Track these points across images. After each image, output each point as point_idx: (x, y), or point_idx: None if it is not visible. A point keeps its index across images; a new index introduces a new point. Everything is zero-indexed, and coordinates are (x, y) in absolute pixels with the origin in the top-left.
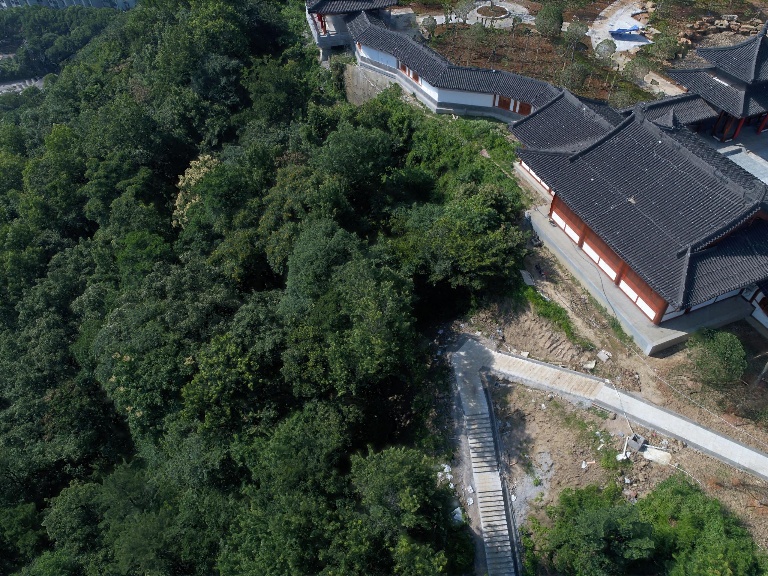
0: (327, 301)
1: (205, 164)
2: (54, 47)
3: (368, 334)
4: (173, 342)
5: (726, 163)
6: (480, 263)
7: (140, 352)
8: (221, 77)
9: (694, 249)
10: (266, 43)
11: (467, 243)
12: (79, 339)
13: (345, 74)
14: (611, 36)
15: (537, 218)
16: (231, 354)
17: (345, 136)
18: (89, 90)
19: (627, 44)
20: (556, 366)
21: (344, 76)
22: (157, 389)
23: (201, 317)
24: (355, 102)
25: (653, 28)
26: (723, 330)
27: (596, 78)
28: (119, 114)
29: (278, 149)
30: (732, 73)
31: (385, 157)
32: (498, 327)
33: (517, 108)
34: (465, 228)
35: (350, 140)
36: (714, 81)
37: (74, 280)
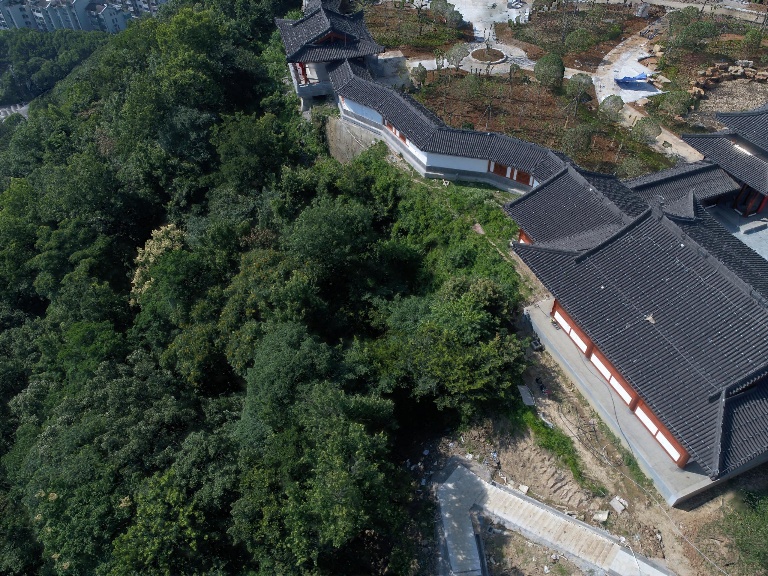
0: (286, 440)
1: (167, 235)
2: (40, 72)
3: (332, 497)
4: (110, 473)
5: (758, 263)
6: (470, 386)
7: (71, 485)
8: (191, 132)
9: (729, 392)
10: (243, 90)
11: (455, 359)
12: (14, 447)
13: (327, 127)
14: (617, 84)
15: (537, 317)
16: (172, 502)
17: (319, 216)
18: (53, 139)
19: (634, 94)
20: (561, 512)
21: (326, 129)
22: (87, 536)
23: (144, 443)
24: (338, 157)
25: (662, 76)
26: (760, 471)
27: (602, 136)
28: (77, 174)
29: (245, 226)
30: (757, 143)
31: (365, 237)
32: (492, 449)
33: (514, 175)
34: (453, 339)
35: (325, 220)
36: (735, 149)
37: (17, 369)
